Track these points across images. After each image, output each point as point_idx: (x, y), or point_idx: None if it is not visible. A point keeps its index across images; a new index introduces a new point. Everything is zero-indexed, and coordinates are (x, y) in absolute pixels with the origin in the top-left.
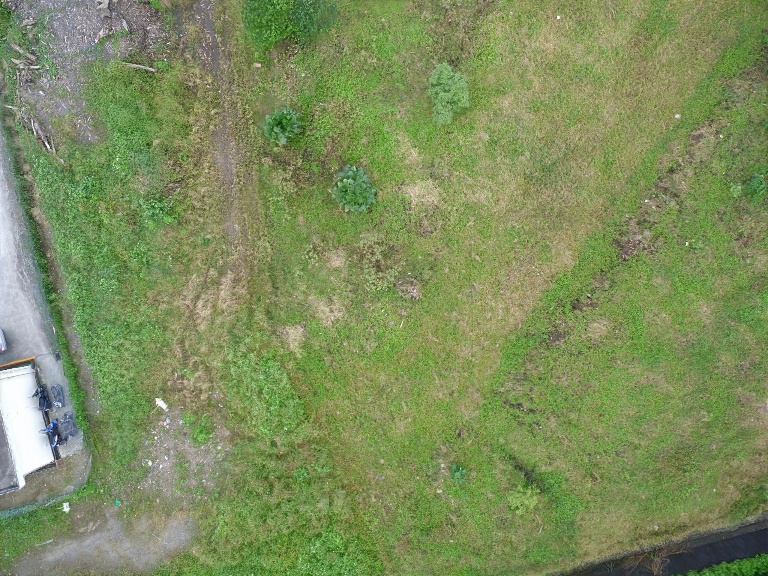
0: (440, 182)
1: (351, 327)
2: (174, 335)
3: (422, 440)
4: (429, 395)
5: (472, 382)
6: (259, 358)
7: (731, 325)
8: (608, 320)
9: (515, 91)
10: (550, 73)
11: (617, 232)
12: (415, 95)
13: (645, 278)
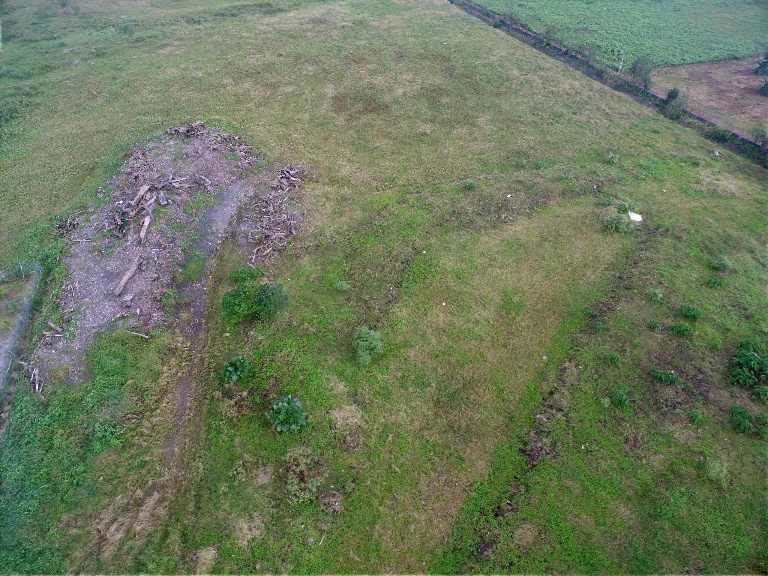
0: (362, 407)
1: (267, 546)
2: (71, 566)
3: None
4: None
5: None
6: None
7: (654, 524)
8: (531, 524)
9: (419, 345)
10: (443, 334)
11: (521, 443)
12: (343, 348)
13: (555, 479)
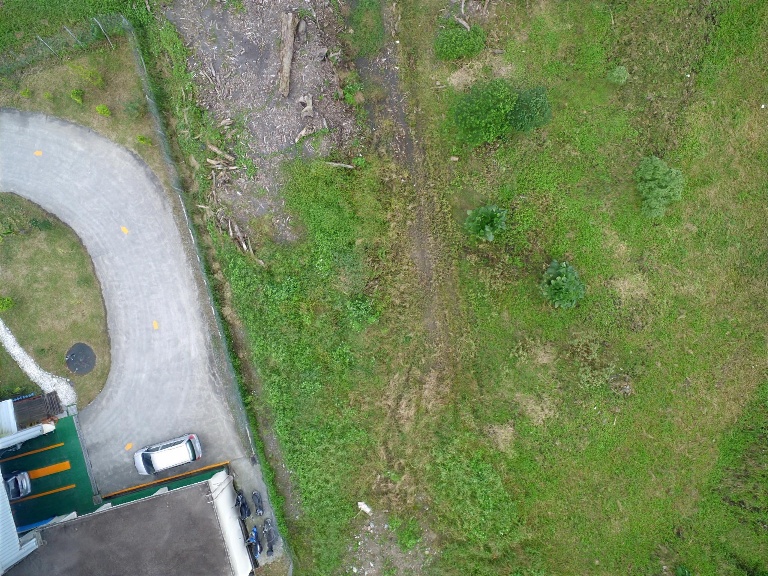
0: (648, 275)
1: (564, 426)
2: (377, 437)
3: (639, 540)
4: (645, 493)
5: (689, 479)
6: (469, 460)
7: None
8: None
9: (721, 181)
10: (757, 162)
11: None
12: (621, 188)
13: None
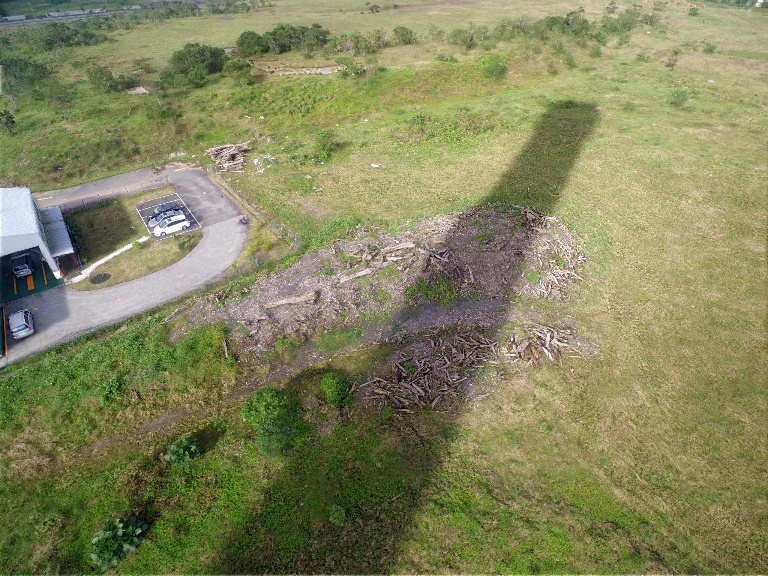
0: None
1: None
2: None
3: None
4: None
5: None
6: None
7: None
8: None
9: None
10: None
11: None
12: (227, 568)
13: None
